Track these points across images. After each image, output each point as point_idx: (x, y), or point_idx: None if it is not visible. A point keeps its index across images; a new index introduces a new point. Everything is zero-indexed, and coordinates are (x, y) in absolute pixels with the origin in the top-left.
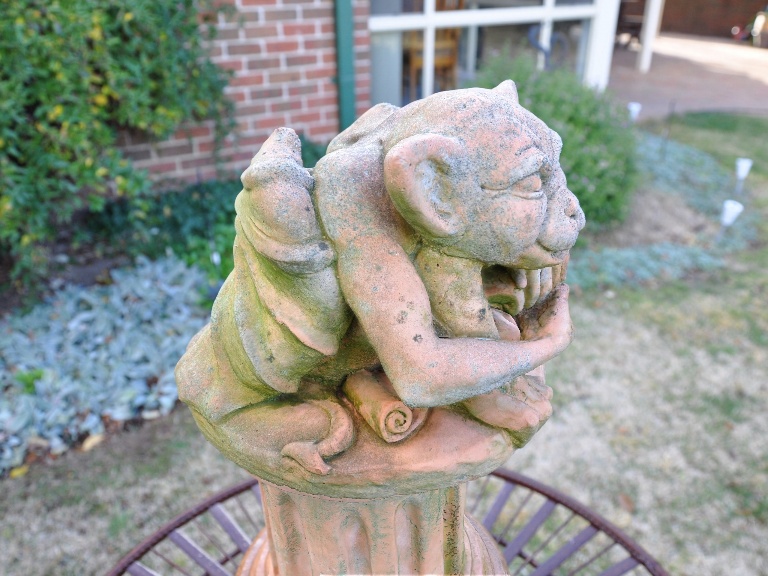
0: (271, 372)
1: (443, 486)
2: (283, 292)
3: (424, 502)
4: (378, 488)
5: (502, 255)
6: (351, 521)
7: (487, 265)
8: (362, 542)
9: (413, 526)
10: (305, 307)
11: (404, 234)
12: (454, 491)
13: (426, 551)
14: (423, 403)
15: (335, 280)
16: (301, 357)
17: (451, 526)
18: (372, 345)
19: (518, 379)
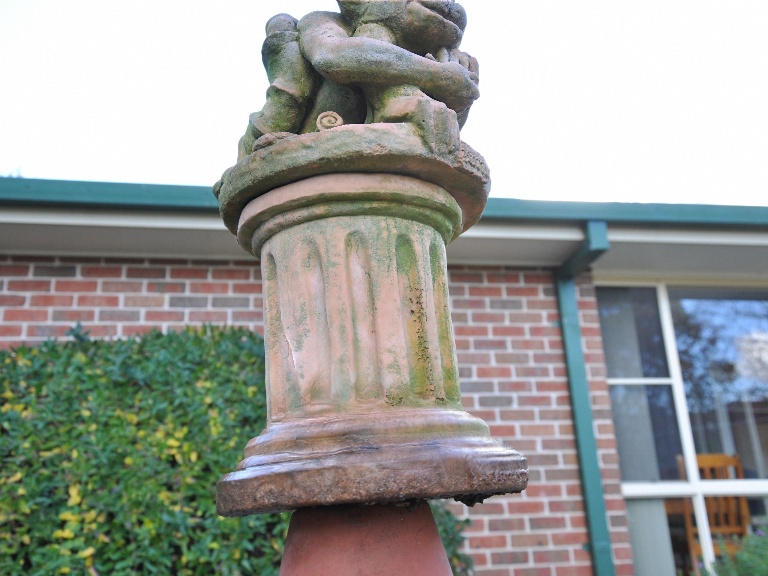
0: (260, 122)
1: (355, 148)
2: (275, 78)
3: (371, 239)
4: (307, 151)
5: (393, 7)
6: (313, 265)
7: (397, 37)
8: (322, 289)
9: (367, 276)
10: (283, 74)
11: (342, 24)
12: (415, 271)
13: (378, 299)
14: (327, 58)
15: (298, 46)
16: (279, 107)
17: (419, 320)
18: (308, 56)
19: (419, 91)
